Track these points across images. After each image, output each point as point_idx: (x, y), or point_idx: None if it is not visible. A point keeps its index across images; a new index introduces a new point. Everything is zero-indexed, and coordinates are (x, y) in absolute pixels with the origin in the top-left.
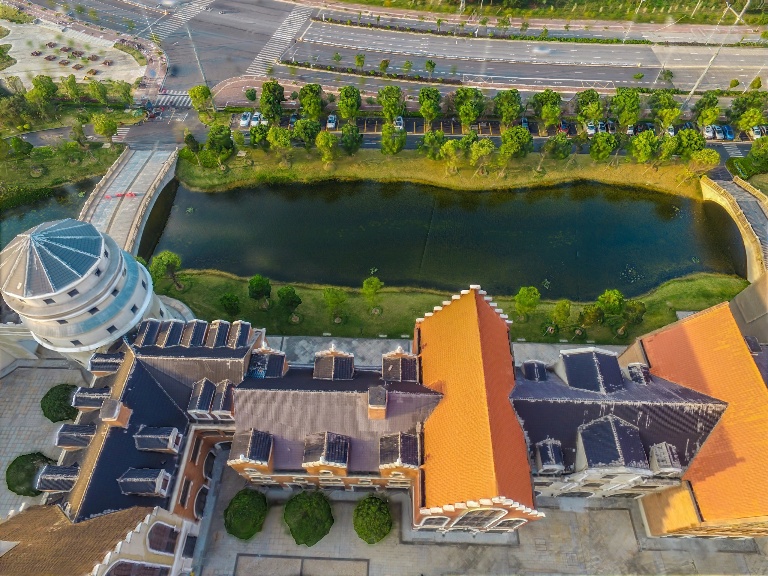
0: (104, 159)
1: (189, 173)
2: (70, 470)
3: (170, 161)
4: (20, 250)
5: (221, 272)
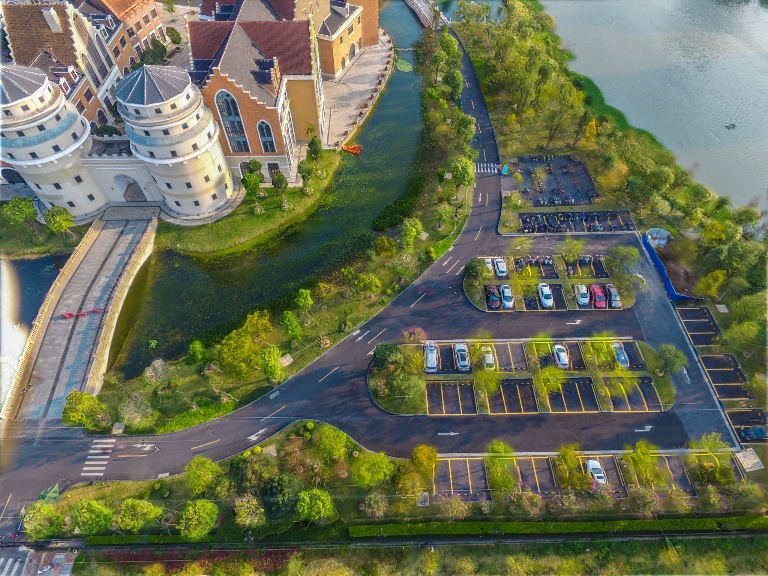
0: (122, 400)
1: (2, 381)
2: (55, 70)
3: (13, 382)
4: (7, 66)
5: (2, 257)
